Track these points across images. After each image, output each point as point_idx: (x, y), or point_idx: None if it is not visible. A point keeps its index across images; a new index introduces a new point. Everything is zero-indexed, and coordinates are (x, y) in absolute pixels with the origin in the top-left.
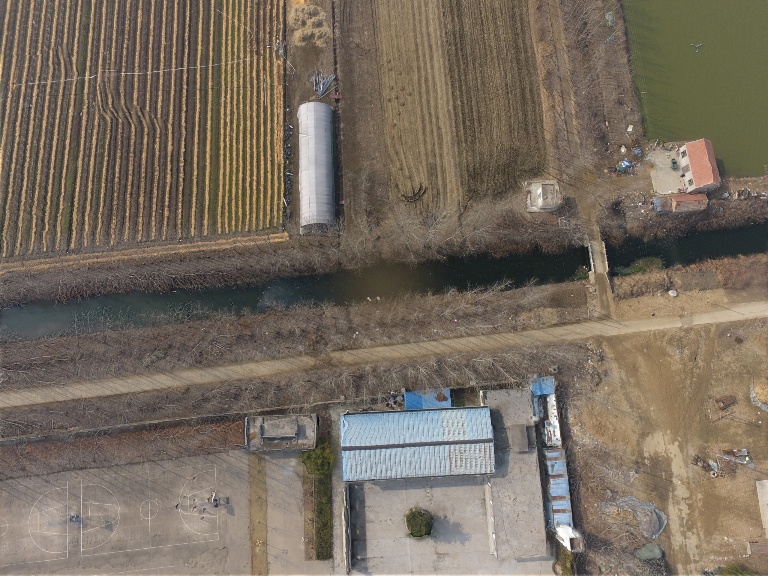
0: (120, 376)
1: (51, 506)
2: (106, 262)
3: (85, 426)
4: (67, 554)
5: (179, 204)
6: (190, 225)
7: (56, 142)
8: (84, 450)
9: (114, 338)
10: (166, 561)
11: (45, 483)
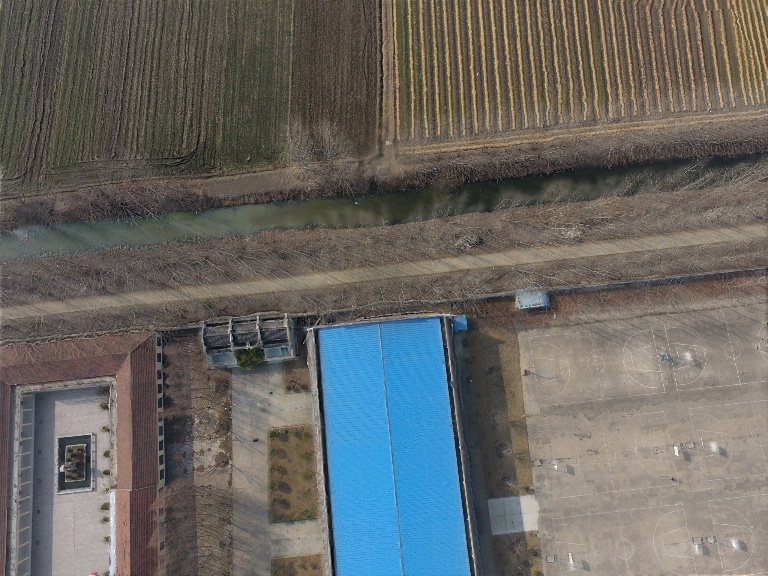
0: (689, 230)
1: (641, 346)
2: (647, 130)
3: (667, 273)
4: (664, 389)
5: (704, 78)
6: (718, 97)
7: (577, 22)
8: (661, 297)
9: (665, 199)
10: (758, 396)
11: (631, 326)
